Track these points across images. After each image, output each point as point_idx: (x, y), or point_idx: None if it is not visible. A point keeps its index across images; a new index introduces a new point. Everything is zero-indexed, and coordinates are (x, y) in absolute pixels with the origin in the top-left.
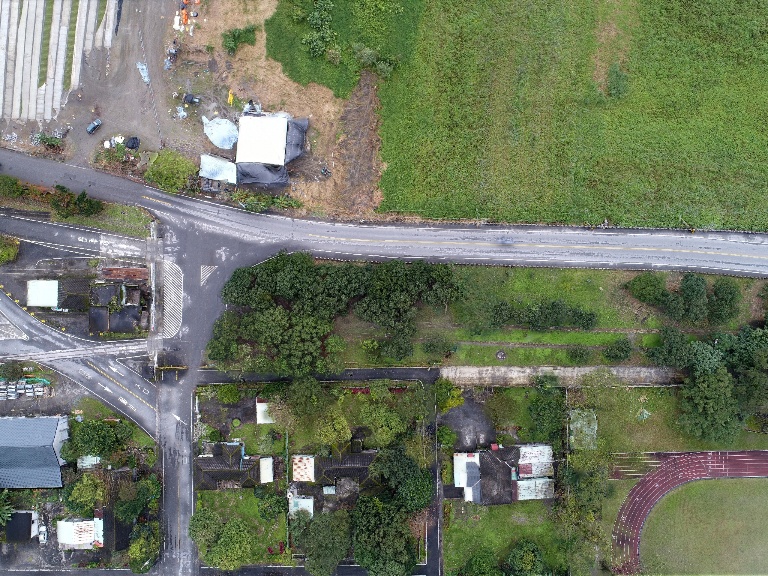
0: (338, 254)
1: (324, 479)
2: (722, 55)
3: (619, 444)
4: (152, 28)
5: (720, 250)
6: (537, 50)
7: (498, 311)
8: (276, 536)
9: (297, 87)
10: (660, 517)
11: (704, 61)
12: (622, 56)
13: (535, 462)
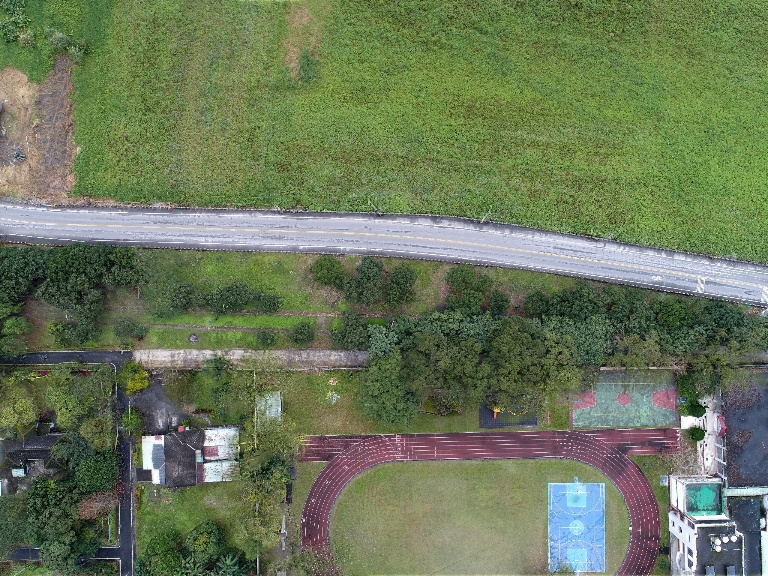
0: (32, 238)
1: (8, 461)
2: (412, 40)
3: (309, 427)
4: None
5: (408, 233)
6: (229, 35)
7: (177, 294)
8: None
9: None
10: (349, 499)
11: (393, 46)
12: (314, 41)
13: (221, 444)
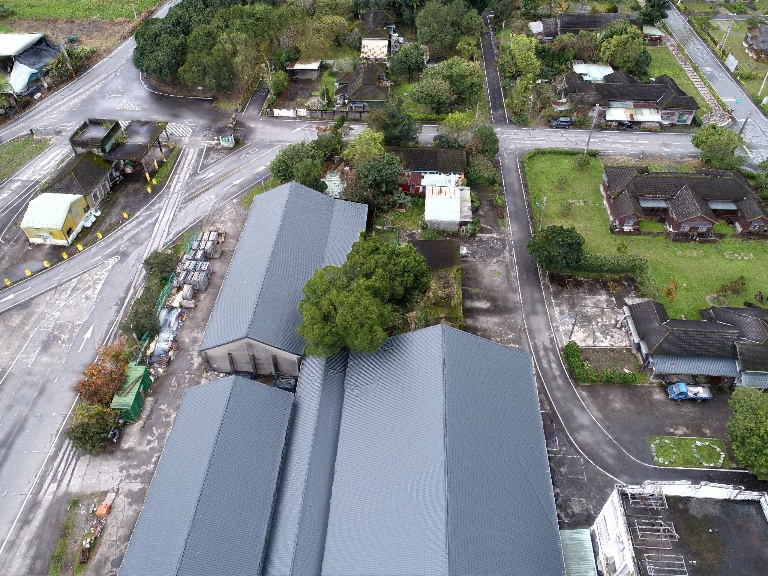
0: None
1: (384, 32)
2: None
3: None
4: None
5: None
6: None
7: None
8: None
9: None
10: None
11: None
12: None
13: None
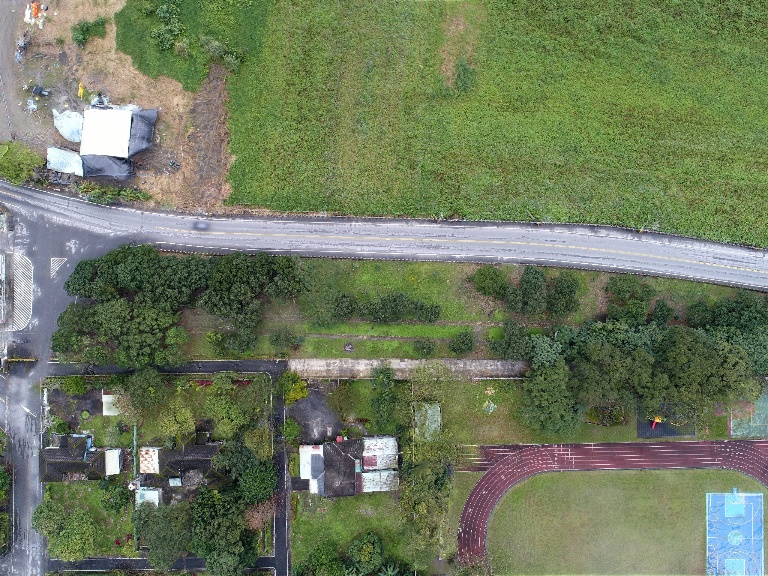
0: (187, 247)
1: (168, 471)
2: (569, 49)
3: (465, 436)
4: (3, 22)
5: (566, 243)
6: (385, 44)
7: (339, 303)
8: (125, 528)
9: (147, 80)
10: (506, 509)
11: (551, 55)
12: (470, 50)
13: (379, 454)
